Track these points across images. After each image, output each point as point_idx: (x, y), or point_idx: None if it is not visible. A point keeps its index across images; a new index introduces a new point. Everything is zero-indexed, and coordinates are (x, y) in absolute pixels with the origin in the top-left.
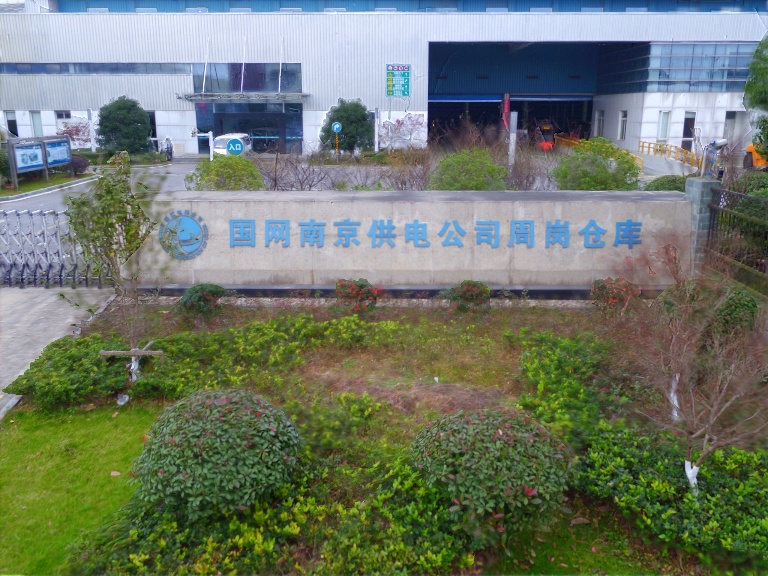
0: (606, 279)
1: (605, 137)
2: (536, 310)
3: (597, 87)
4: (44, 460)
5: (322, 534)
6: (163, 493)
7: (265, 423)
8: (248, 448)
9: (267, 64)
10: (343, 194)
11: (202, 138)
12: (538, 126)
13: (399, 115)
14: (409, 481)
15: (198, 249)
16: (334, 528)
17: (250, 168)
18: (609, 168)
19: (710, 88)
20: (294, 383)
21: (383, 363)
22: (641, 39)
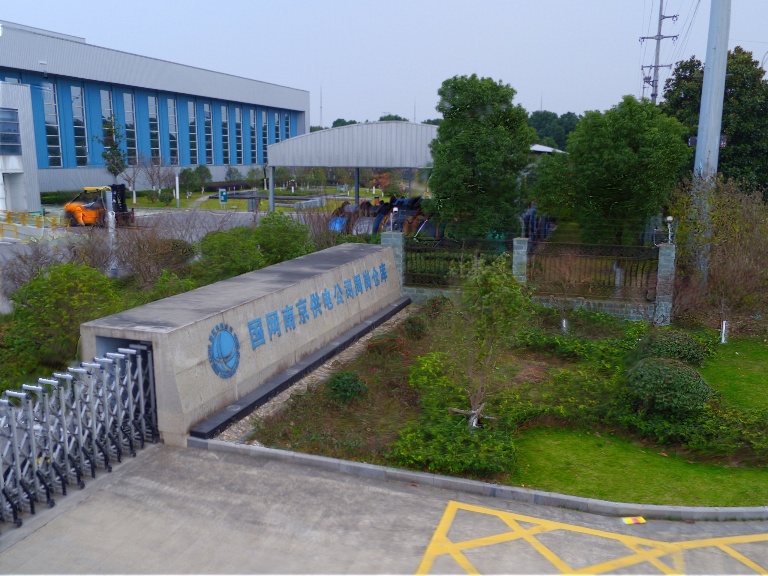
0: None
1: None
2: None
3: None
4: (586, 473)
5: None
6: None
7: None
8: None
9: None
10: (254, 281)
11: None
12: None
13: None
14: None
15: (235, 361)
16: None
17: None
18: None
19: None
20: None
21: None
22: None
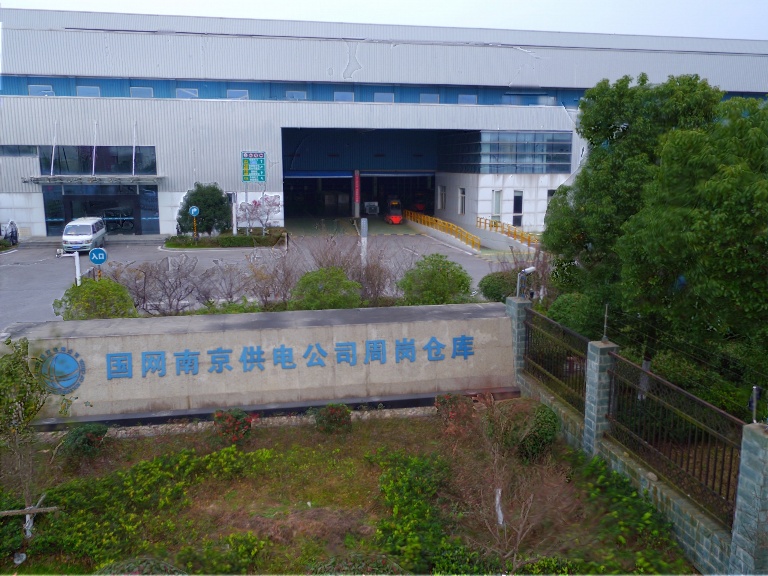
0: (446, 394)
1: (447, 210)
2: (391, 421)
3: (438, 164)
4: None
5: None
6: None
7: None
8: None
9: (119, 147)
10: (214, 321)
11: (50, 220)
12: (387, 201)
13: (255, 196)
14: None
15: (75, 383)
16: None
17: (120, 292)
18: (446, 280)
19: (533, 170)
20: (185, 527)
21: (261, 491)
22: (472, 128)
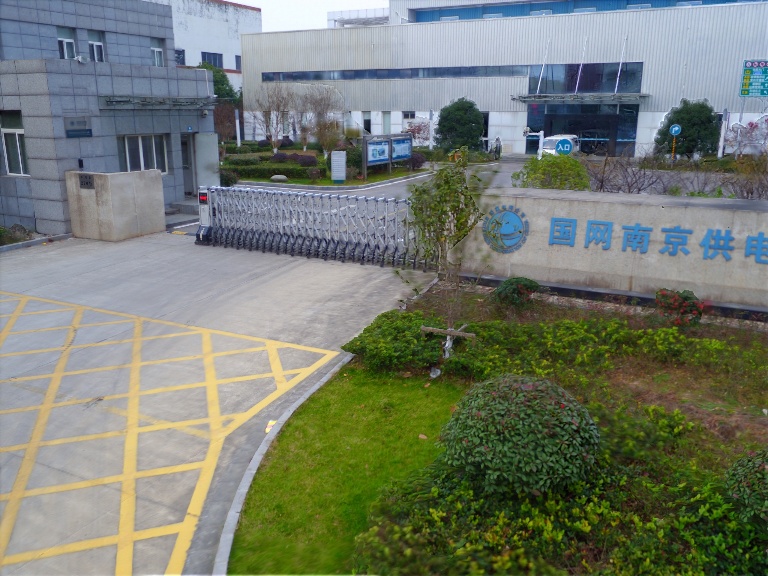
0: None
1: None
2: None
3: None
4: (367, 412)
5: (613, 540)
6: (465, 460)
7: (568, 416)
8: (549, 436)
9: (606, 64)
10: (676, 199)
11: (530, 139)
12: None
13: (753, 117)
14: (719, 511)
15: (517, 244)
16: (627, 537)
17: (578, 168)
18: None
19: None
20: (600, 386)
21: (701, 383)
22: None
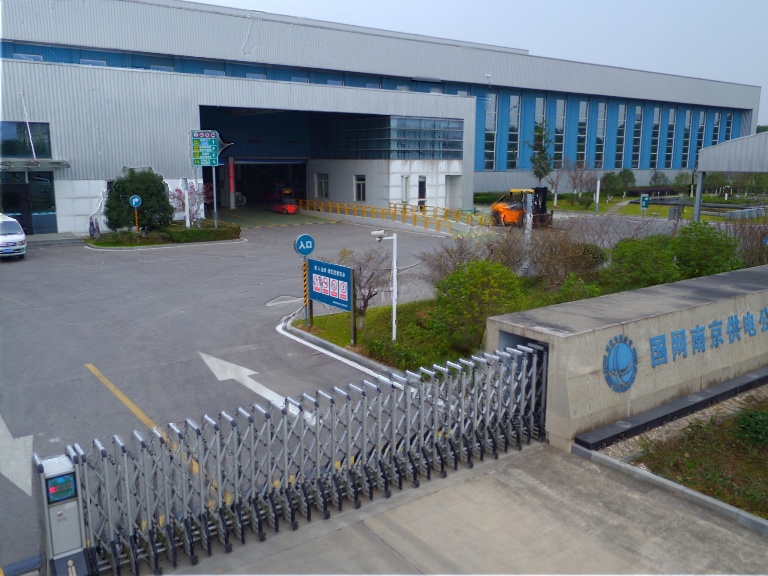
0: None
1: (334, 198)
2: None
3: (311, 151)
4: None
5: None
6: None
7: None
8: None
9: (0, 122)
10: (664, 295)
11: None
12: (276, 190)
13: (173, 184)
14: None
15: (631, 376)
16: None
17: None
18: None
19: (433, 156)
20: None
21: None
22: (384, 113)
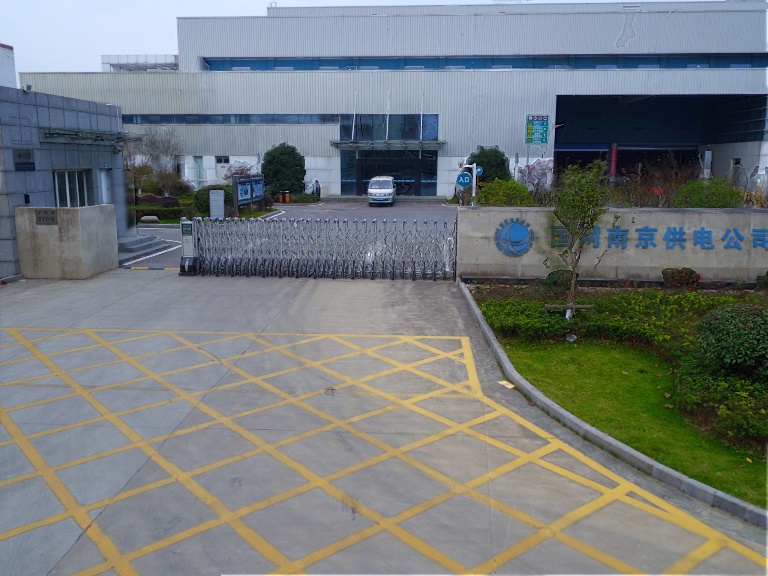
0: None
1: None
2: None
3: (702, 137)
4: (565, 365)
5: None
6: (748, 357)
7: None
8: None
9: (407, 115)
10: (629, 209)
11: (344, 181)
12: None
13: None
14: None
15: (525, 249)
16: None
17: None
18: None
19: None
20: None
21: None
22: (758, 92)
